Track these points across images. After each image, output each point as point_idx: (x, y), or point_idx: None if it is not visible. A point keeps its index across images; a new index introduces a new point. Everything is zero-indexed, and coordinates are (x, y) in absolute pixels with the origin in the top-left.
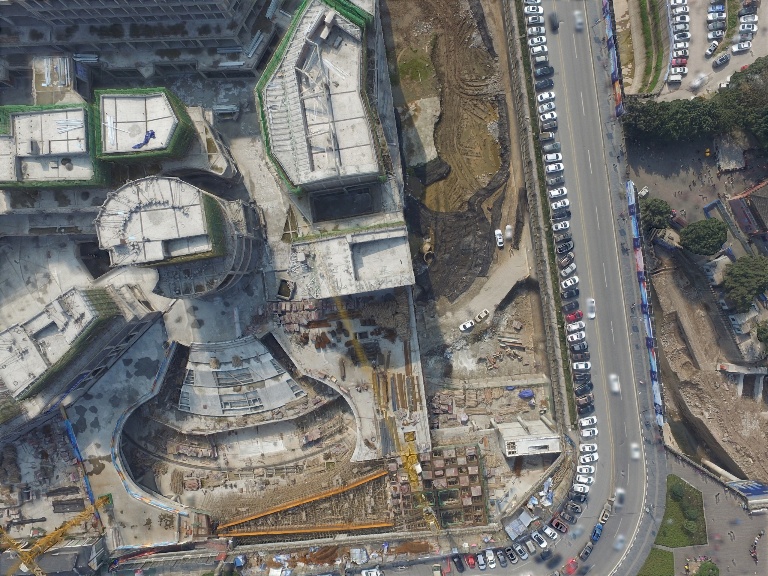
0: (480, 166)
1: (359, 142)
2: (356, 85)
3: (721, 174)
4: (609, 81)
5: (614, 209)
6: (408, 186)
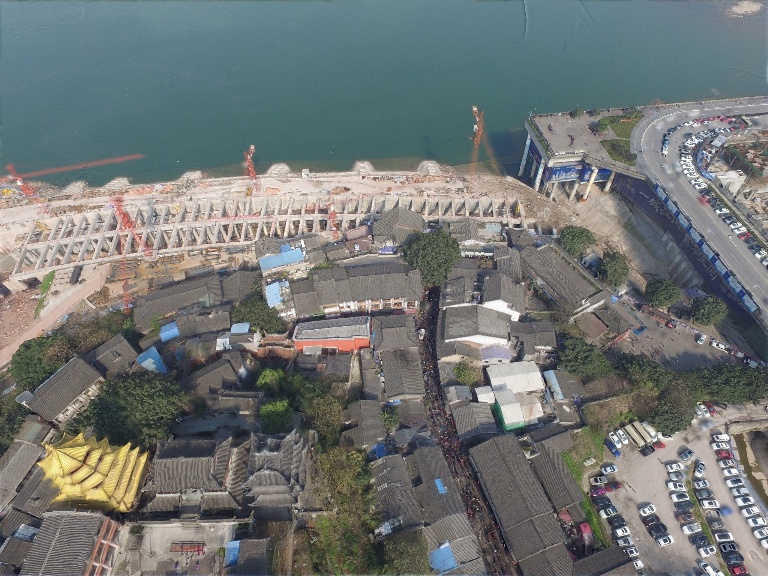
0: None
1: None
2: None
3: None
4: None
5: None
6: None
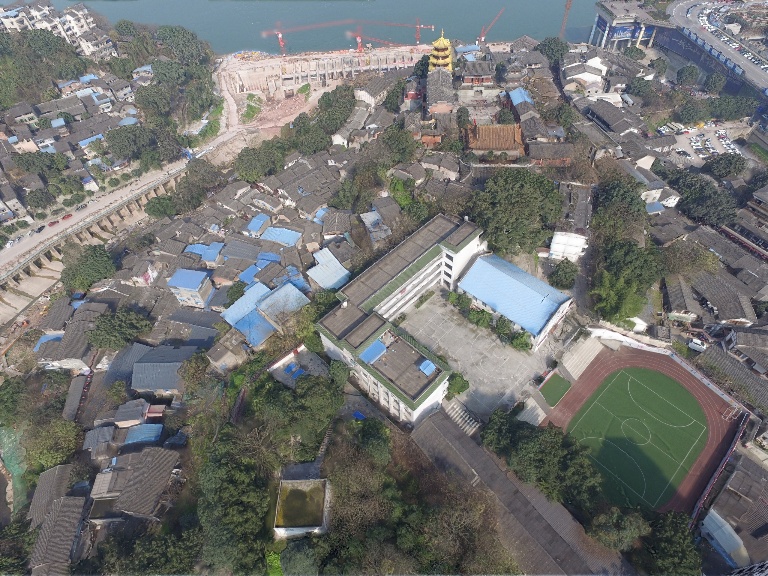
0: None
1: None
2: None
3: None
4: None
5: None
6: None
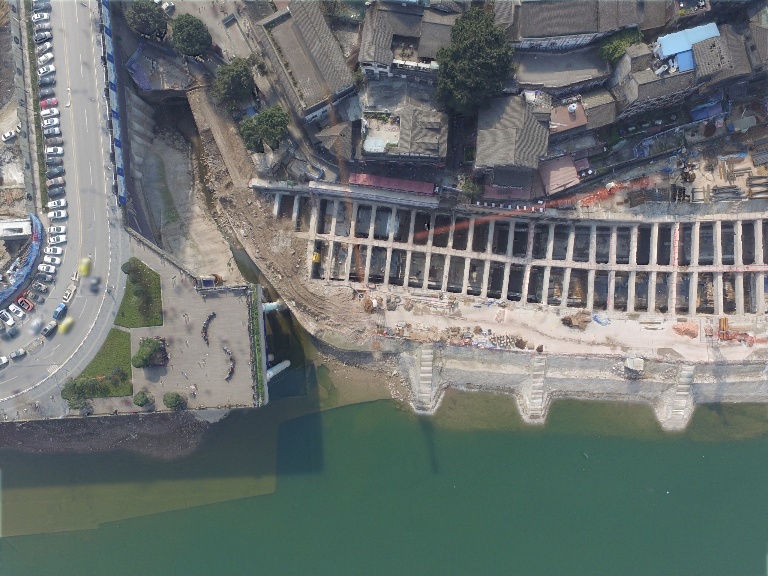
0: None
1: None
2: None
3: None
4: None
5: (90, 2)
6: None
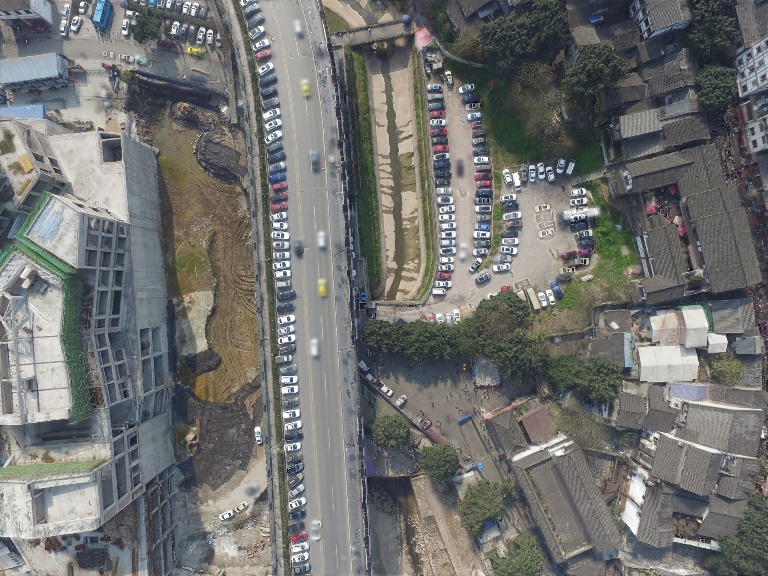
0: (250, 359)
1: (58, 385)
2: (58, 330)
3: (477, 389)
4: (348, 309)
5: (345, 434)
6: (179, 374)
